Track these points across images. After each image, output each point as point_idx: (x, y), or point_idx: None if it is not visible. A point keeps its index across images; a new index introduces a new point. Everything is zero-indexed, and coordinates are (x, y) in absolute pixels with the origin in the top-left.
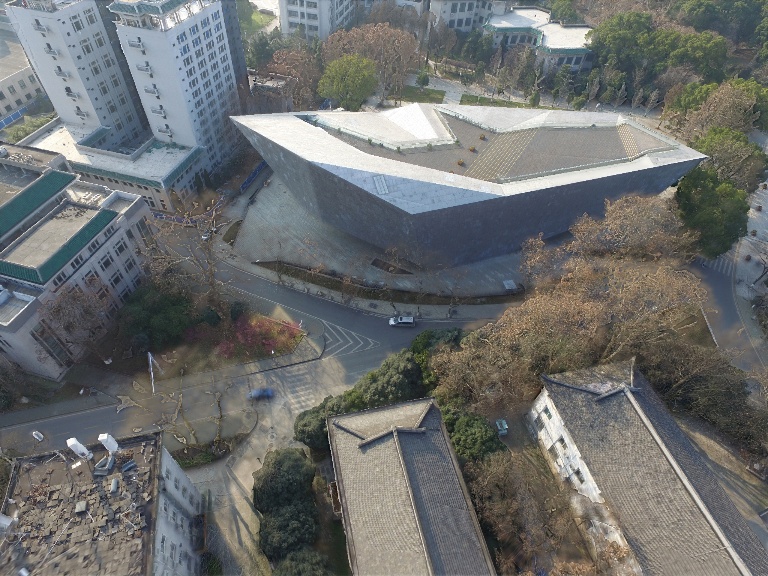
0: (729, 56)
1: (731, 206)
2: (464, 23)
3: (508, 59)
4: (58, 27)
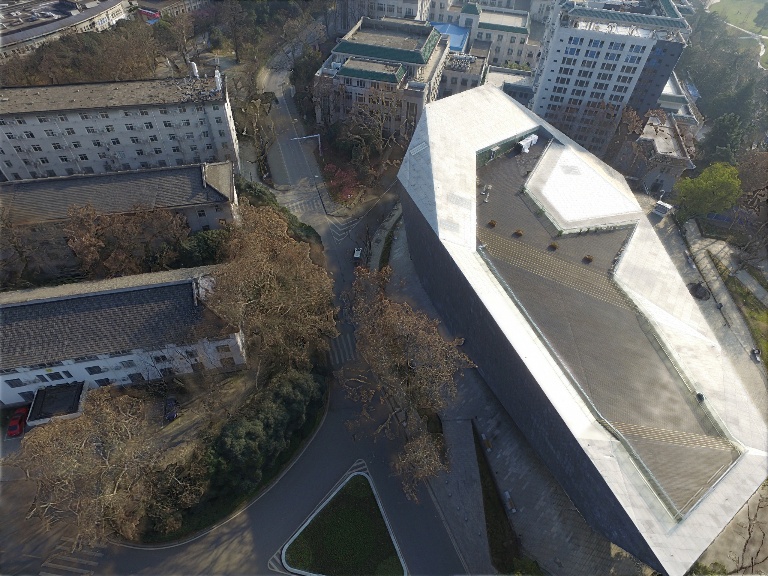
0: None
1: None
2: None
3: None
4: (556, 8)
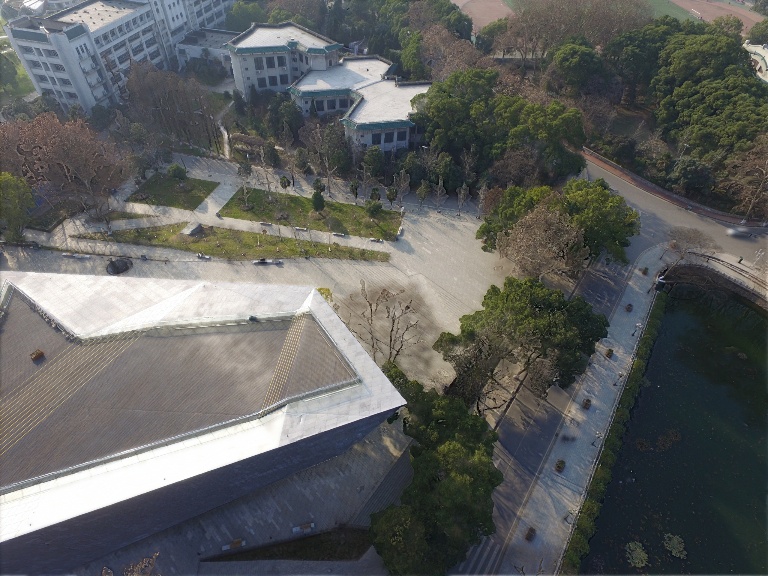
0: (610, 122)
1: (448, 497)
2: (279, 81)
3: (303, 138)
4: None
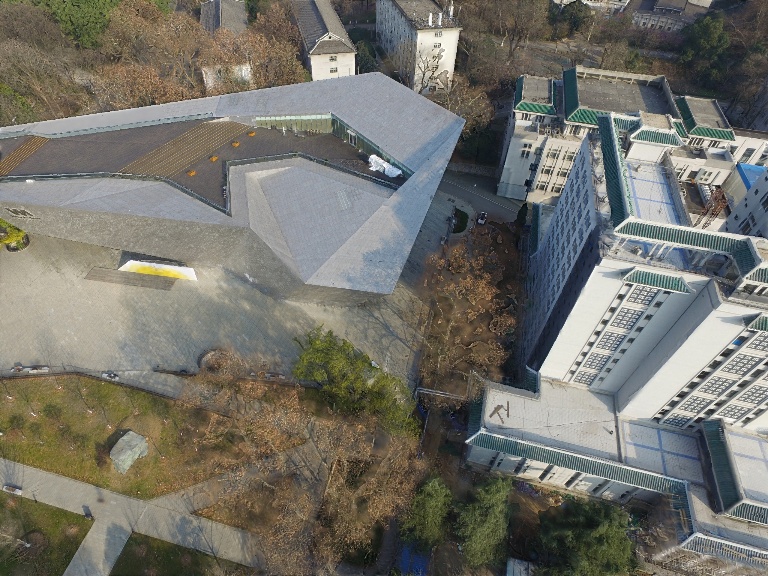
0: None
1: None
2: None
3: None
4: None
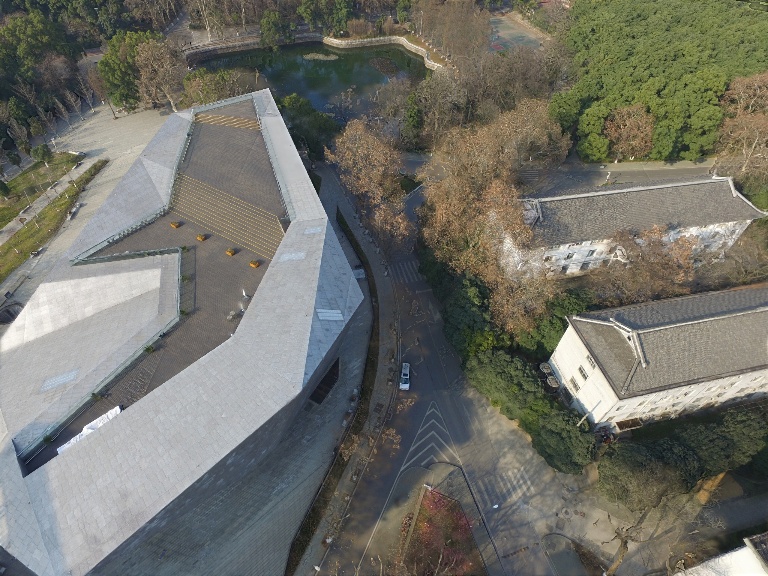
0: None
1: (309, 107)
2: None
3: None
4: None
